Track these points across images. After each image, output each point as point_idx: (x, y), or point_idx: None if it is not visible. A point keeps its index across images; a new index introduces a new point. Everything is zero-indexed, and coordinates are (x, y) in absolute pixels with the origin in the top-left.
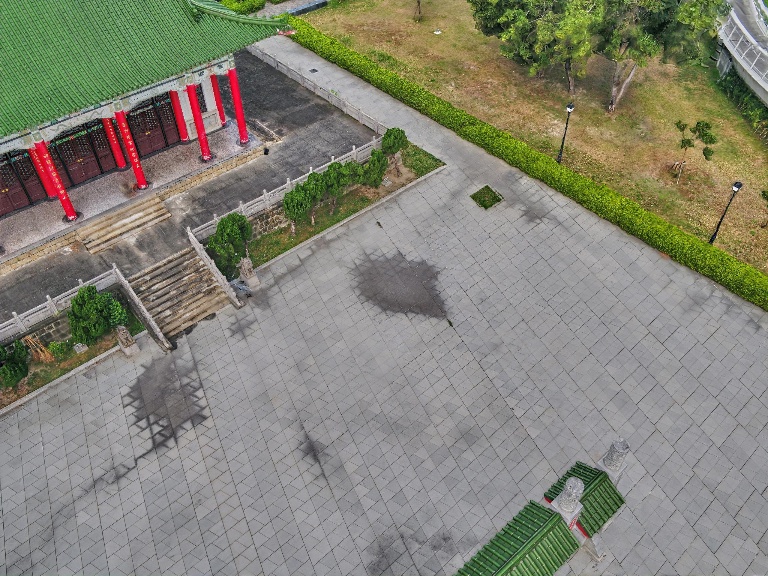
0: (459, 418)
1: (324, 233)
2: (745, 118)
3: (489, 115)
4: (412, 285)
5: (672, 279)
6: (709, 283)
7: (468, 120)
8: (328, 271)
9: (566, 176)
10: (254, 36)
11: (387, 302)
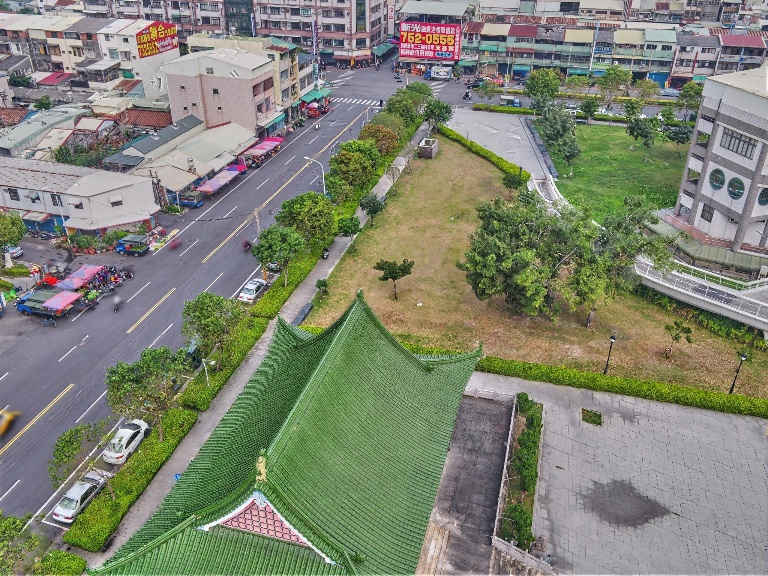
0: (752, 572)
1: (537, 492)
2: (656, 305)
3: (522, 356)
4: (628, 500)
5: (735, 424)
6: (751, 418)
7: (525, 366)
8: (573, 518)
9: (622, 382)
10: (470, 369)
11: (629, 520)
